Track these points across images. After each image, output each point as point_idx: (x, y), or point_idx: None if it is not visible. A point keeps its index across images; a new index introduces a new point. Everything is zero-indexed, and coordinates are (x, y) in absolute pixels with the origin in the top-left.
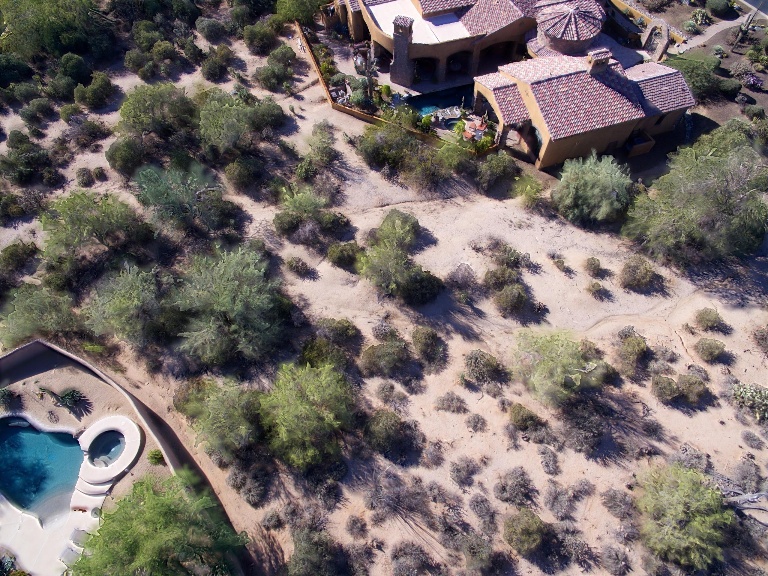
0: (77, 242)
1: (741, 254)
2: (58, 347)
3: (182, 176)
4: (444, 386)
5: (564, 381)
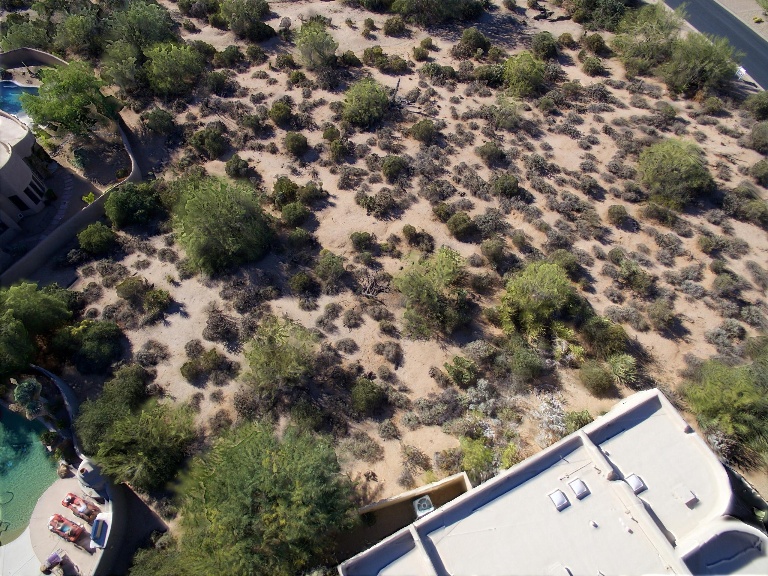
0: None
1: (466, 22)
2: None
3: None
4: None
5: (328, 64)
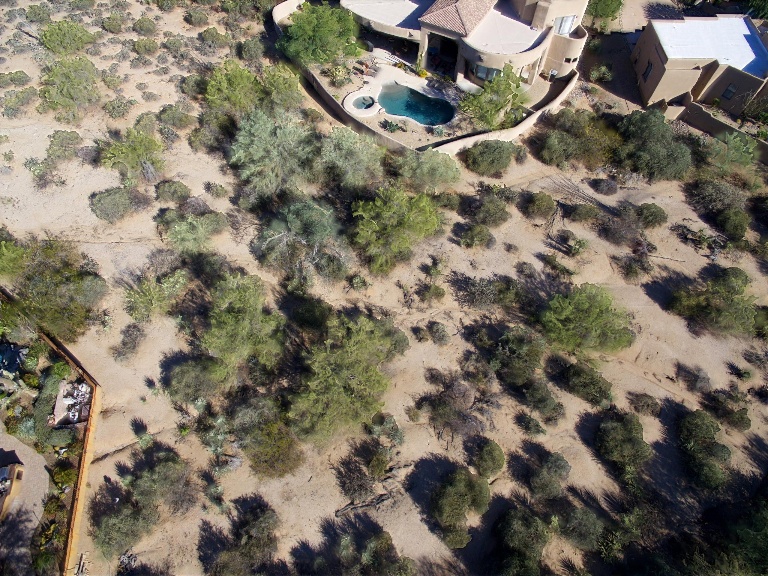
0: (392, 190)
1: None
2: (403, 145)
3: None
4: (150, 105)
5: None
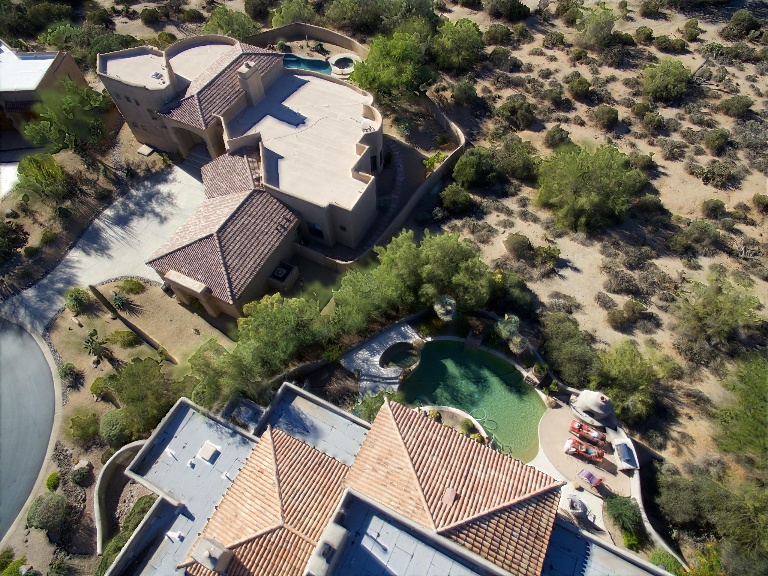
0: None
1: (717, 5)
2: None
3: None
4: None
5: None
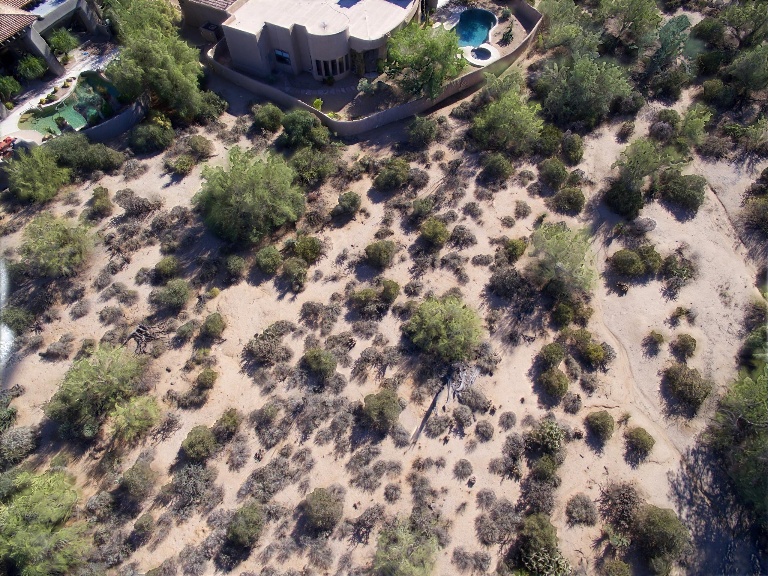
0: (615, 7)
1: (756, 535)
2: None
3: (699, 65)
4: (536, 208)
5: None
